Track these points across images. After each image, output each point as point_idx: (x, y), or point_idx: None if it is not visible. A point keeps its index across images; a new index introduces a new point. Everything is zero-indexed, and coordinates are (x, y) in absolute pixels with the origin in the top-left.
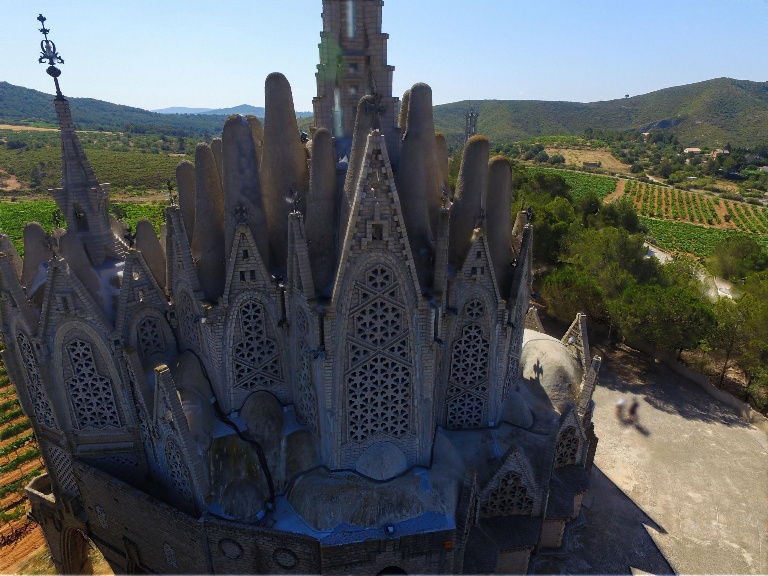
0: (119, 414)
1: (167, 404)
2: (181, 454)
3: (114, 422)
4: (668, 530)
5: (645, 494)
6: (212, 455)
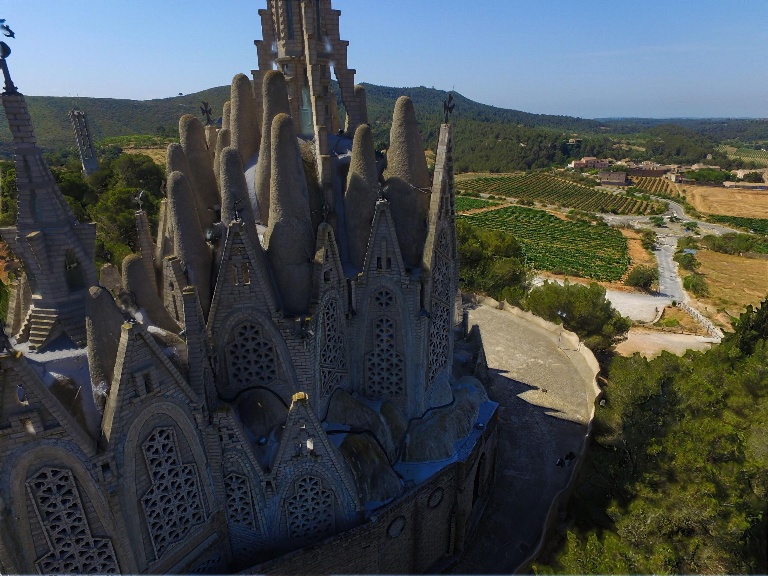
0: (204, 504)
1: (308, 433)
2: (322, 481)
3: (197, 519)
4: (509, 370)
5: None
6: (349, 461)
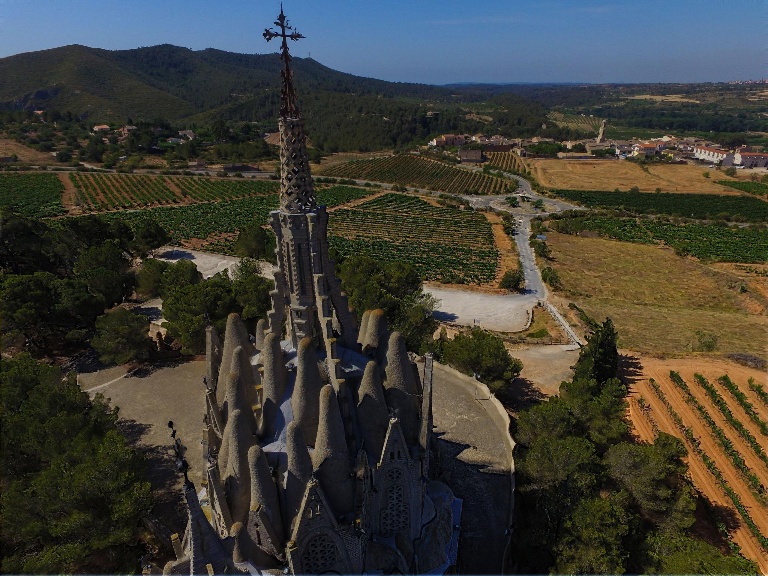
0: None
1: None
2: None
3: None
4: (444, 431)
5: None
6: None
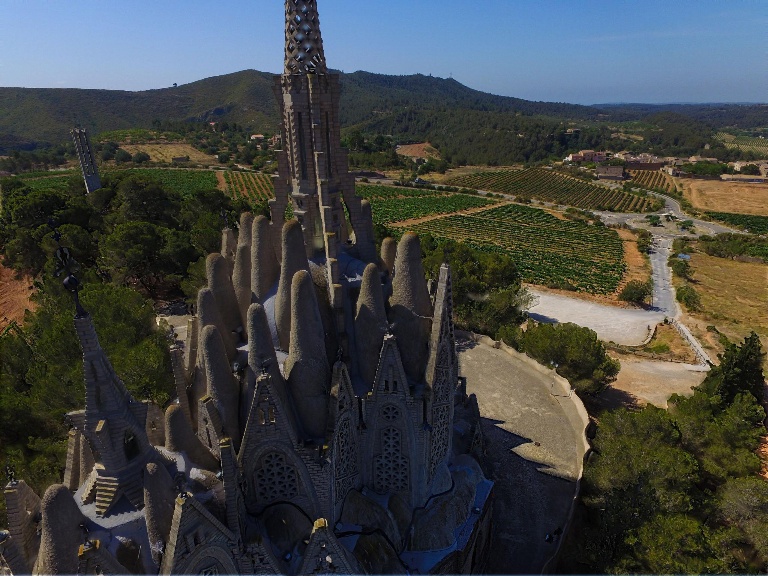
0: None
1: (328, 551)
2: None
3: None
4: (504, 420)
5: (481, 409)
6: (362, 564)
